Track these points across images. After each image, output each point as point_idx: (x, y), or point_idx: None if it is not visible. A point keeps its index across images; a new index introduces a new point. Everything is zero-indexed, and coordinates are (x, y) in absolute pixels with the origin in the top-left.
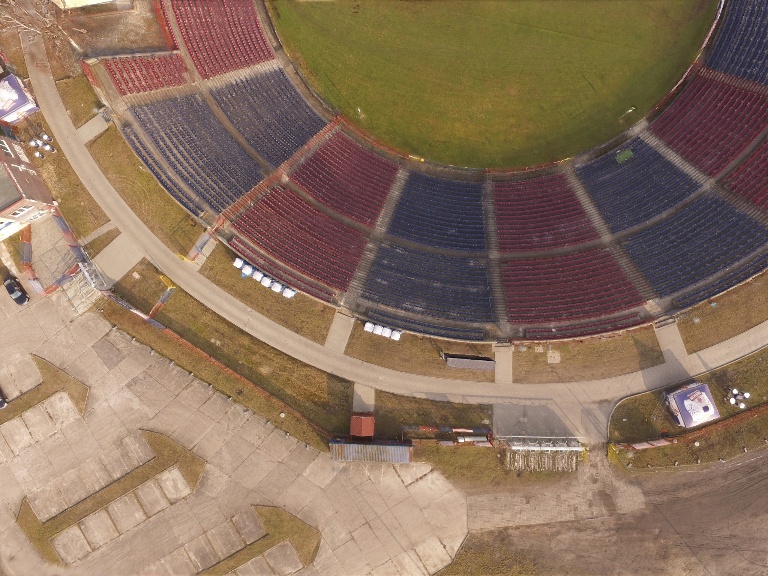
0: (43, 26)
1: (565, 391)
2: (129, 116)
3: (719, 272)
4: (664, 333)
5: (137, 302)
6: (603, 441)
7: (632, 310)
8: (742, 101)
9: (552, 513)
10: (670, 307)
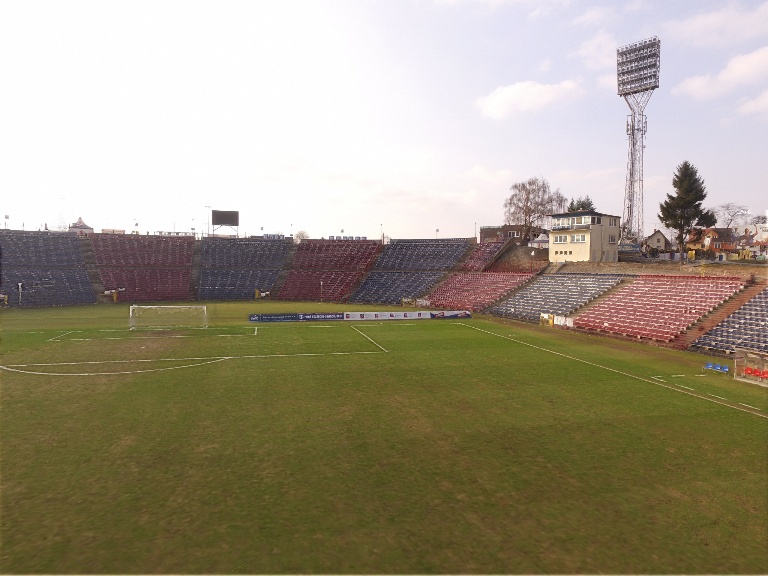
0: None
1: None
2: None
3: None
4: None
5: None
6: None
7: None
8: None
9: None
10: None
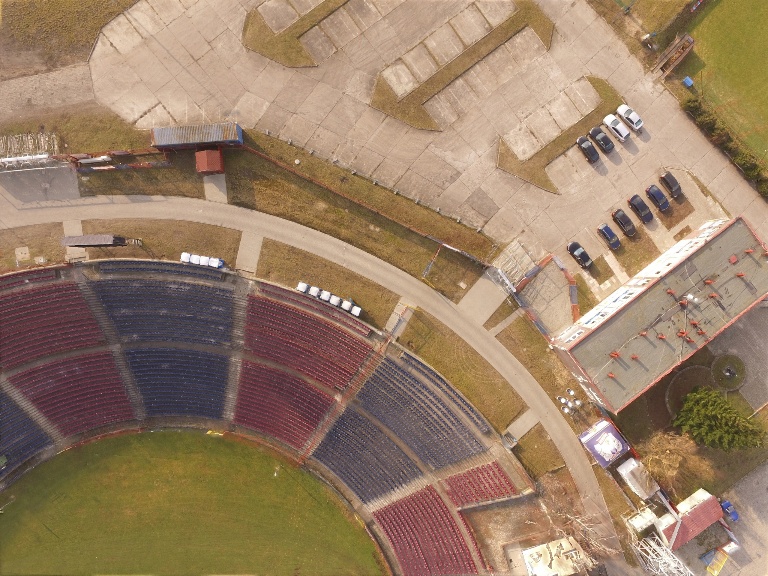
0: None
1: (6, 220)
2: (487, 442)
3: None
4: None
5: (458, 259)
6: None
7: None
8: None
9: (2, 92)
10: None
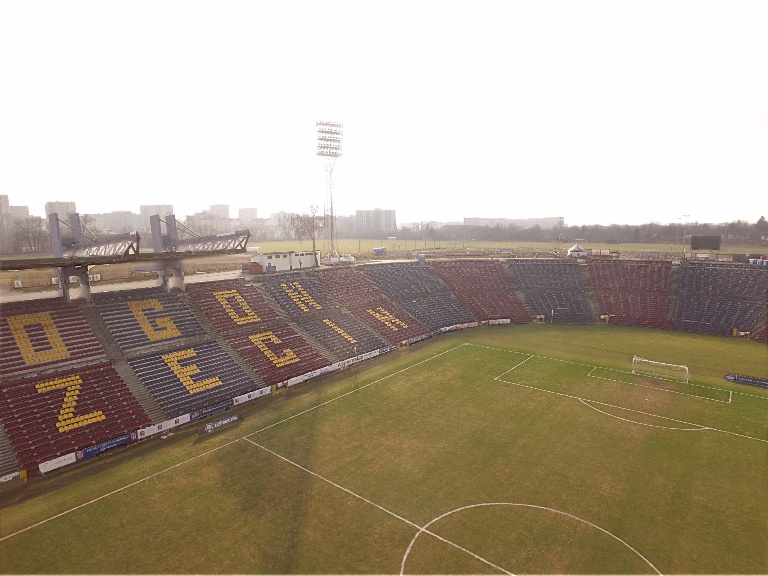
0: None
1: None
2: None
3: None
4: None
5: None
6: None
7: None
8: None
9: None
10: None
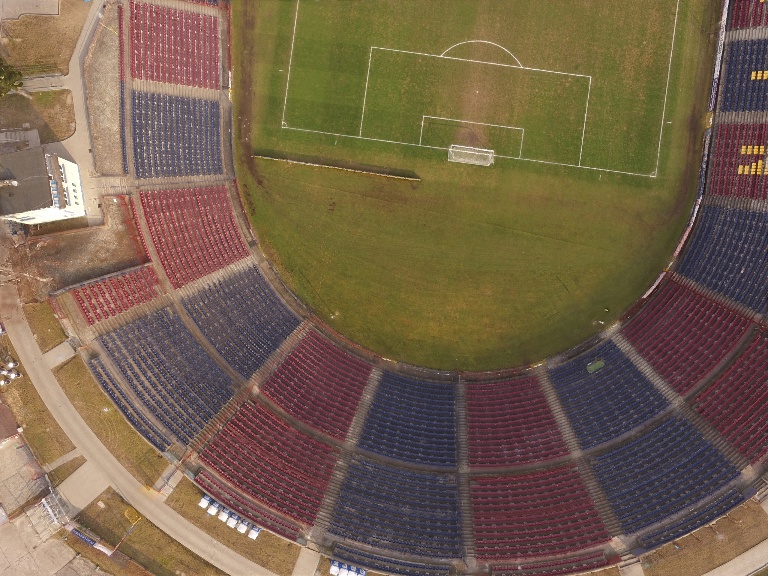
0: (11, 246)
1: None
2: (96, 346)
3: (684, 510)
4: (628, 573)
5: (102, 532)
6: None
7: (597, 547)
8: (712, 315)
9: None
10: (635, 544)
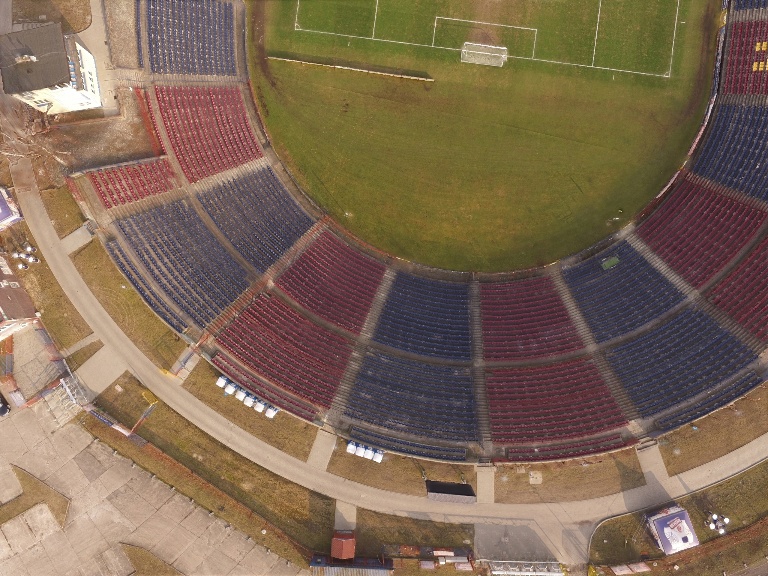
0: (28, 134)
1: (546, 512)
2: (114, 229)
3: (701, 393)
4: (646, 455)
5: (119, 415)
6: (583, 562)
7: (614, 430)
8: (728, 210)
9: None
10: (652, 428)
